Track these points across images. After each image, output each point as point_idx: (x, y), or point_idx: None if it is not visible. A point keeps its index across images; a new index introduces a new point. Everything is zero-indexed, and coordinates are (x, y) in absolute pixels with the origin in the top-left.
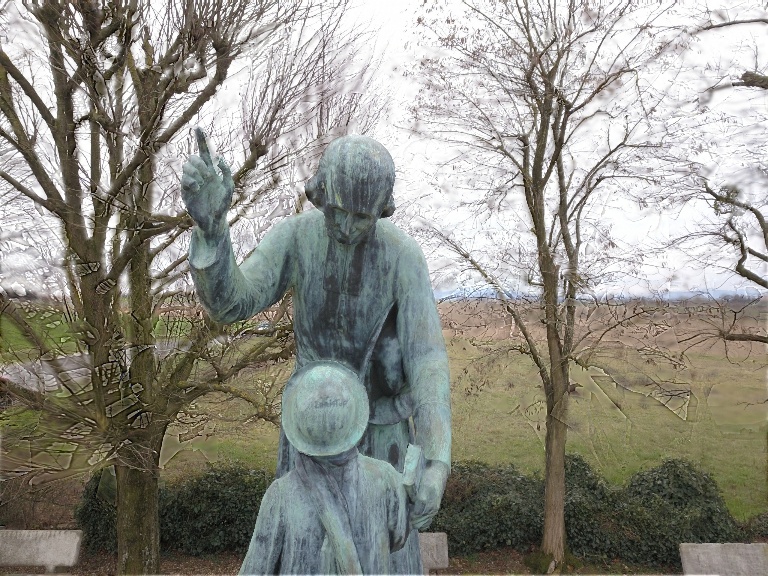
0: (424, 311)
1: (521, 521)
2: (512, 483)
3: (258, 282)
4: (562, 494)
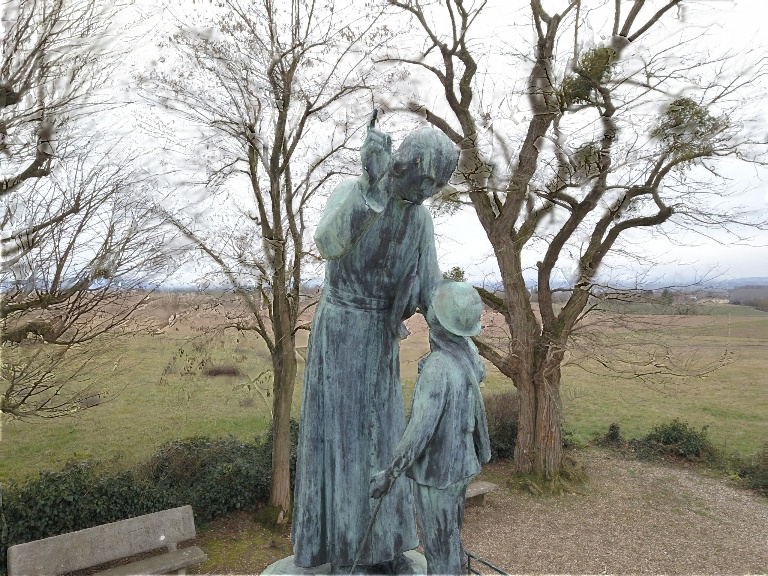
0: None
1: (250, 483)
2: (237, 451)
3: None
4: (288, 450)
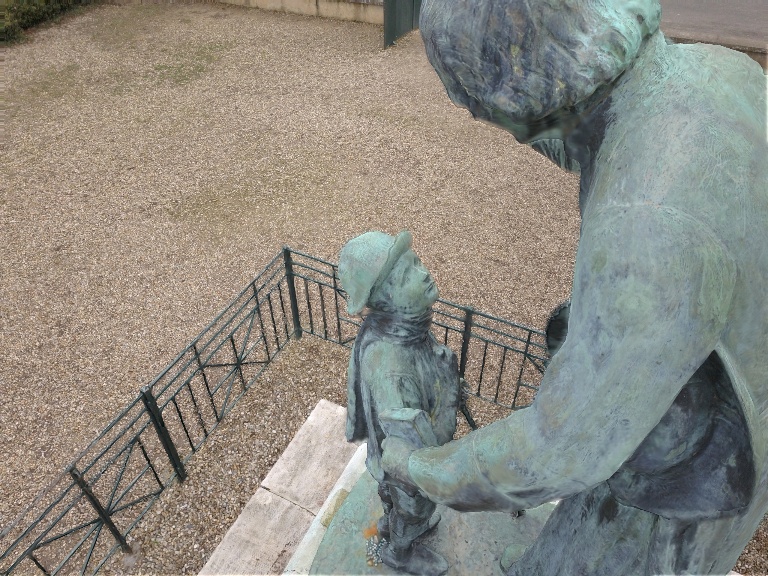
0: (564, 351)
1: None
2: None
3: None
4: None
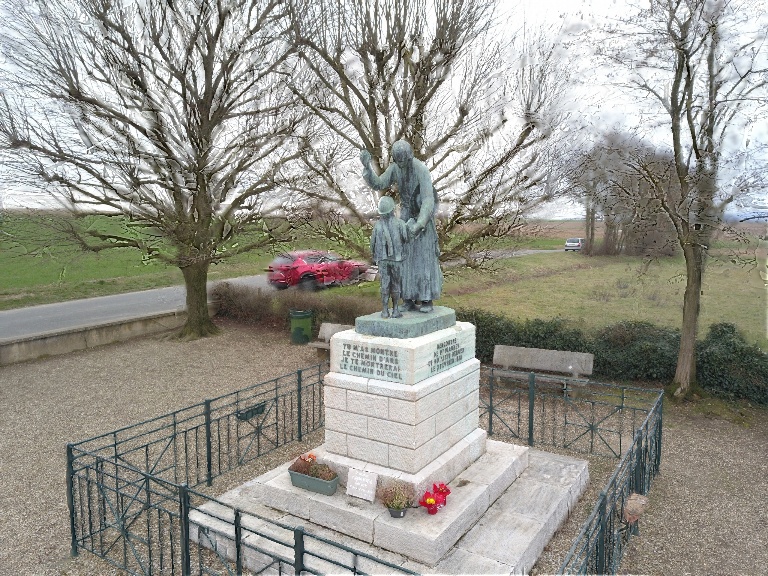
0: (426, 186)
1: (664, 361)
2: (667, 338)
3: (384, 179)
4: (692, 342)
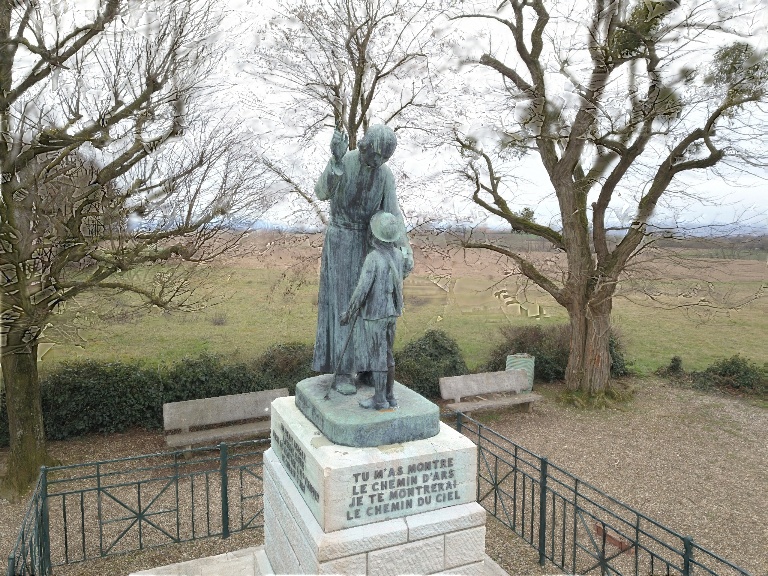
0: (395, 198)
1: None
2: None
3: None
4: None
